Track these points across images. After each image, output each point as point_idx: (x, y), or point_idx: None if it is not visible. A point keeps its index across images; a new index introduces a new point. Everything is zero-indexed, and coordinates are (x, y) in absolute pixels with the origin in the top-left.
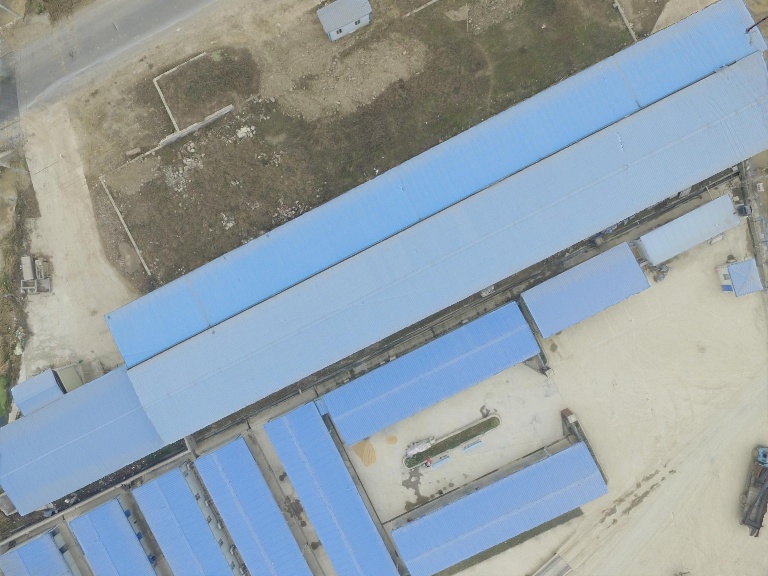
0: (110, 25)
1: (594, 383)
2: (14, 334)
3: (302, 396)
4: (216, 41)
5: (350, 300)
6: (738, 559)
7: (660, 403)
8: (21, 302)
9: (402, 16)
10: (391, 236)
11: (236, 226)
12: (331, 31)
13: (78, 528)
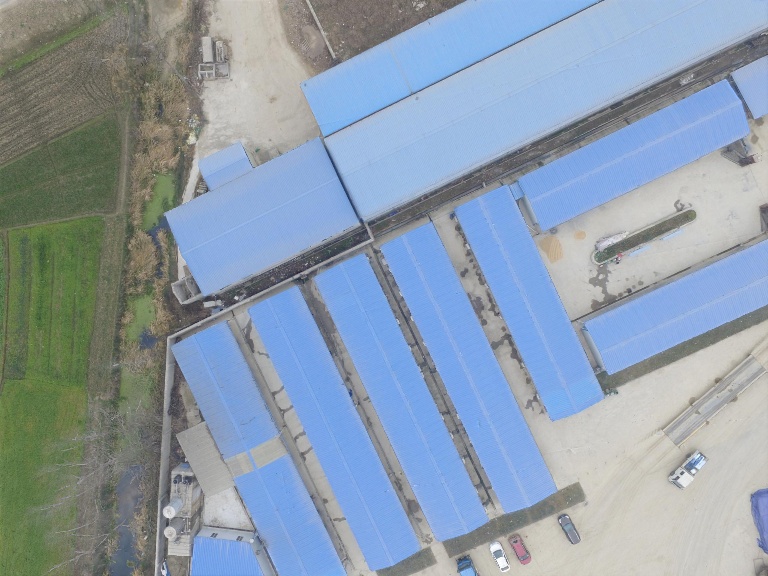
0: None
1: None
2: (187, 124)
3: (487, 189)
4: None
5: (564, 63)
6: None
7: None
8: (197, 88)
9: None
10: None
11: (427, 7)
12: None
13: (257, 315)
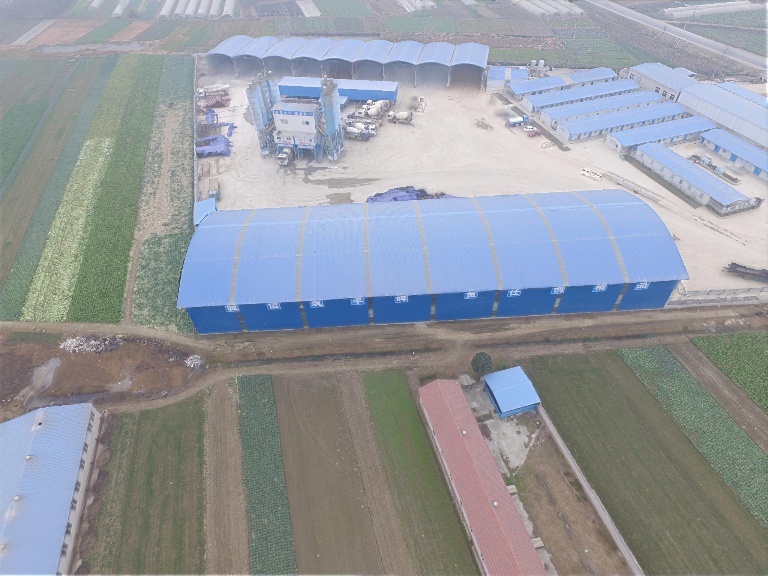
0: None
1: None
2: None
3: None
4: None
5: None
6: None
7: None
8: None
9: None
10: None
11: None
12: None
13: None
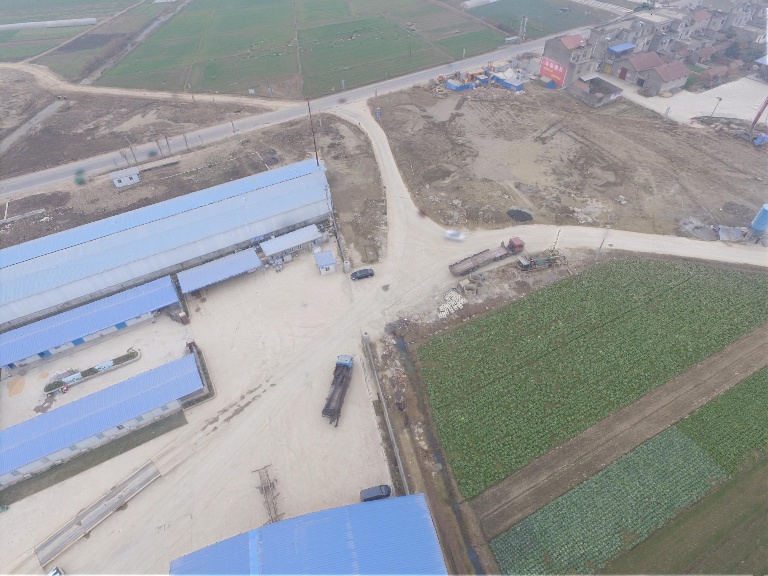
0: (1, 188)
1: (222, 329)
2: None
3: None
4: (54, 190)
5: (49, 266)
6: (326, 456)
7: (270, 338)
8: None
9: (159, 179)
10: (95, 239)
11: None
12: (114, 179)
13: None
